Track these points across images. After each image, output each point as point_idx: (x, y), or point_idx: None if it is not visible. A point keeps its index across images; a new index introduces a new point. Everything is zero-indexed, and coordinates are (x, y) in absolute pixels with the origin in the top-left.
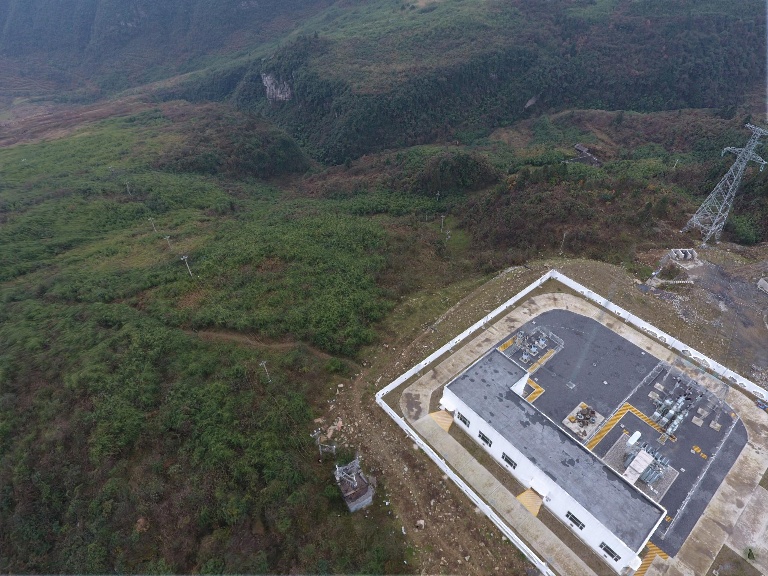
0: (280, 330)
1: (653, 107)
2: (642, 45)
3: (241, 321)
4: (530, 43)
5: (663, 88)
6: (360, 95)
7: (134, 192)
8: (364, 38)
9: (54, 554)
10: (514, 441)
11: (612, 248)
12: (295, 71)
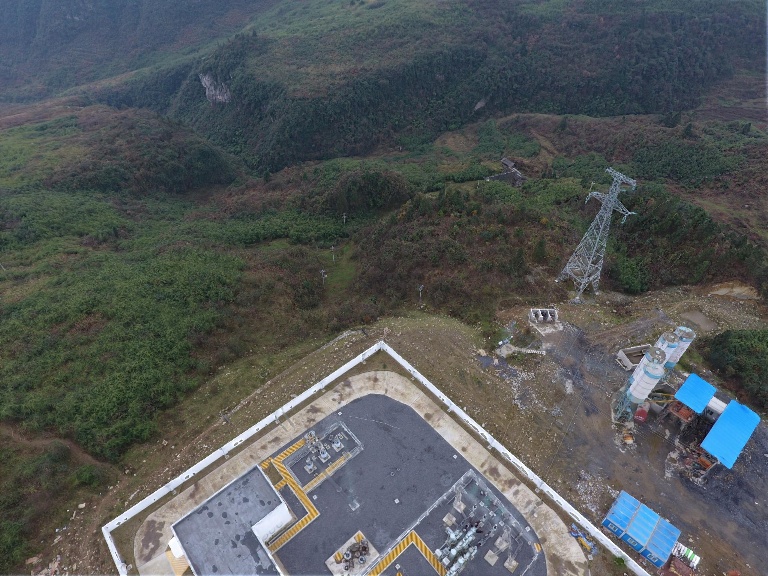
0: (46, 422)
1: (605, 110)
2: (595, 44)
3: (2, 411)
4: (479, 42)
5: (615, 90)
6: (294, 99)
7: (5, 218)
8: (305, 36)
9: None
10: None
11: (473, 303)
12: (232, 72)
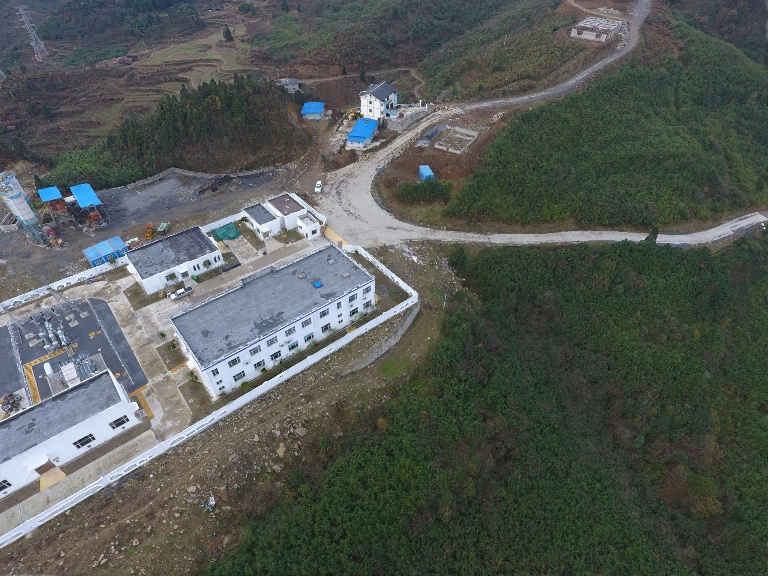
0: None
1: None
2: None
3: None
4: None
5: None
6: None
7: None
8: None
9: None
10: None
11: None
12: None
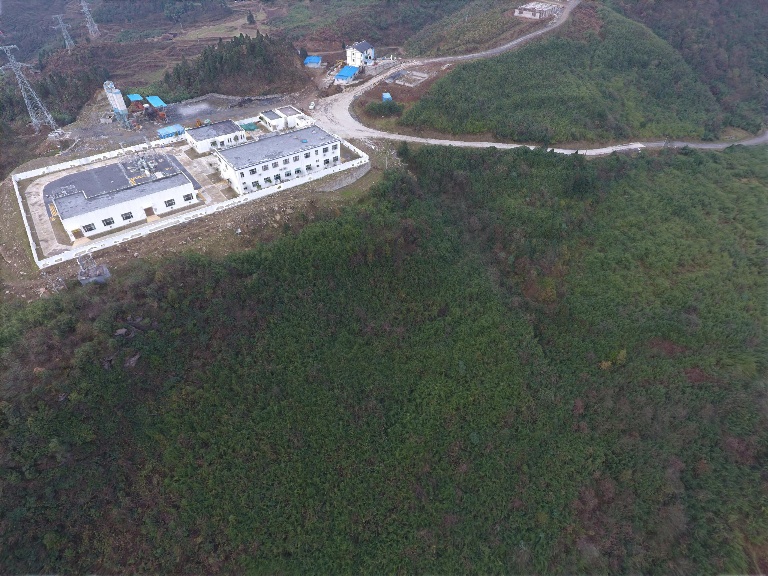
0: None
1: None
2: None
3: None
4: None
5: None
6: None
7: None
8: None
9: (5, 521)
10: (118, 203)
11: (18, 160)
12: None
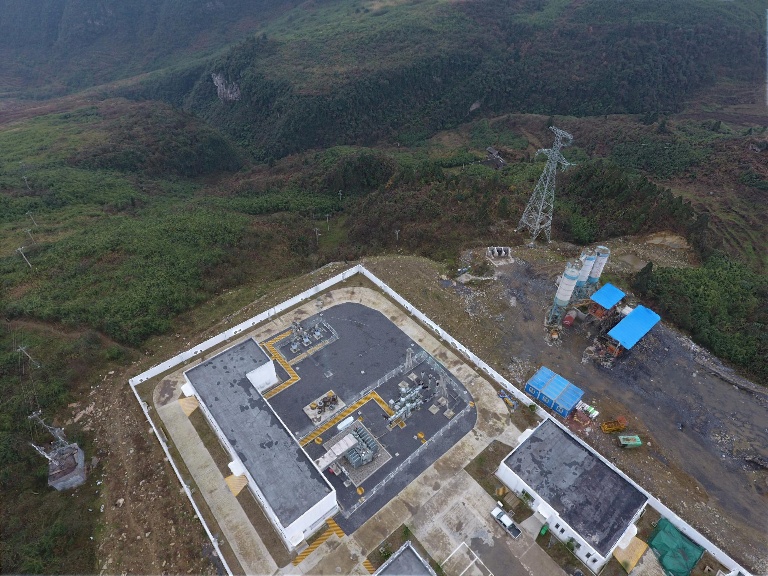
0: (81, 319)
1: (593, 112)
2: (584, 51)
3: (44, 310)
4: (474, 48)
5: (603, 94)
6: (300, 96)
7: (35, 187)
8: (312, 40)
9: None
10: (224, 424)
11: (442, 246)
12: (243, 71)
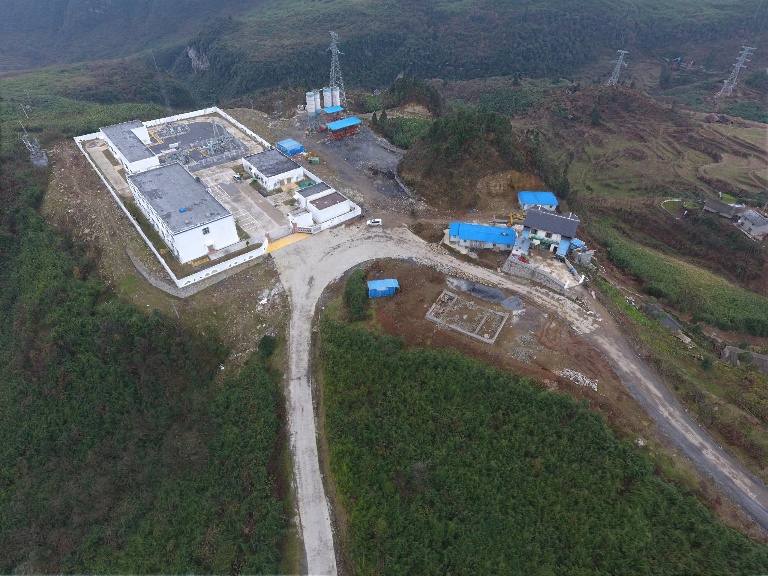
0: None
1: None
2: (489, 33)
3: (34, 124)
4: (401, 28)
5: (502, 67)
6: (252, 62)
7: (35, 102)
8: (268, 20)
9: None
10: (114, 141)
11: None
12: (211, 45)
